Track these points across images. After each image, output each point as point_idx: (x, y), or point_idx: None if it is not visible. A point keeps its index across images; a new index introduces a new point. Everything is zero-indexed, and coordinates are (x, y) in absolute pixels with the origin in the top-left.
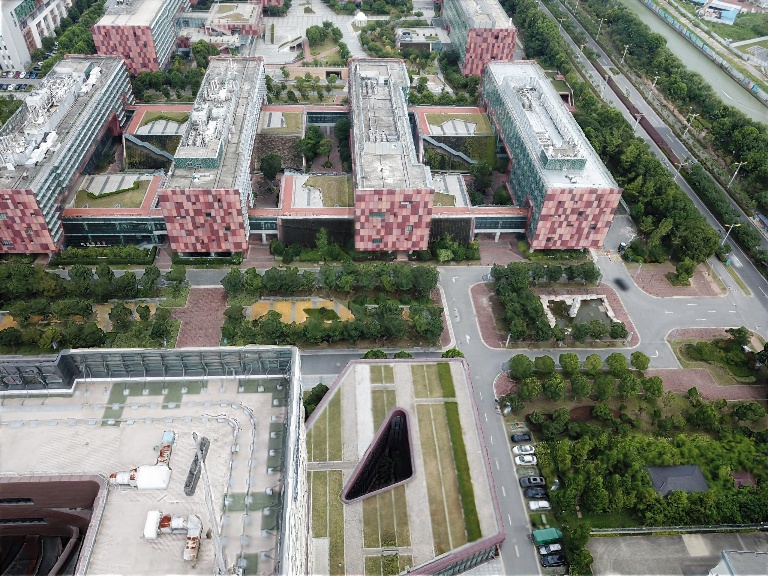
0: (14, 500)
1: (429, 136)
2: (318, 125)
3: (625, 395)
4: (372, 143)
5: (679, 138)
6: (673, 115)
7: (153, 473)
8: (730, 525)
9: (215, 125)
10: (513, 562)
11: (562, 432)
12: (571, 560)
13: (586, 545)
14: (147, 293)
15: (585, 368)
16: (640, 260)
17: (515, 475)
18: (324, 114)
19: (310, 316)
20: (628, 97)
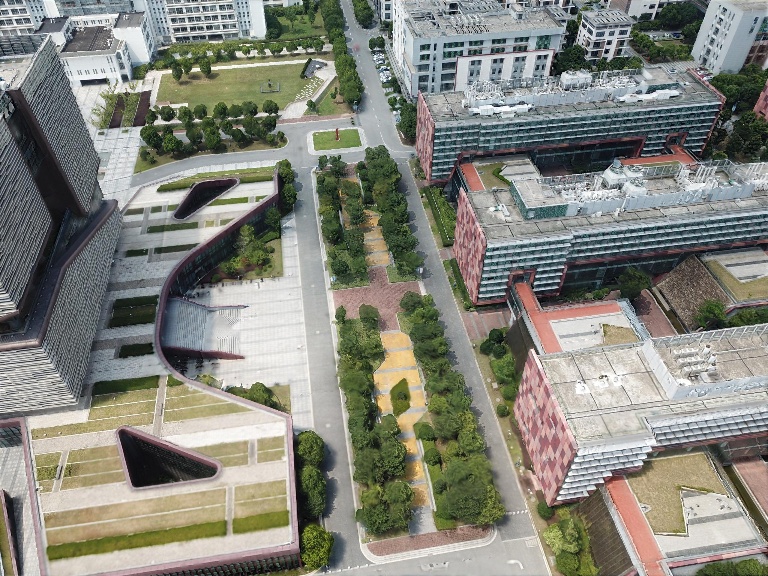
0: None
1: None
2: None
3: None
4: None
5: None
6: None
7: None
8: None
9: (610, 195)
10: None
11: None
12: None
13: None
14: (403, 254)
15: None
16: None
17: None
18: None
19: (395, 386)
20: None
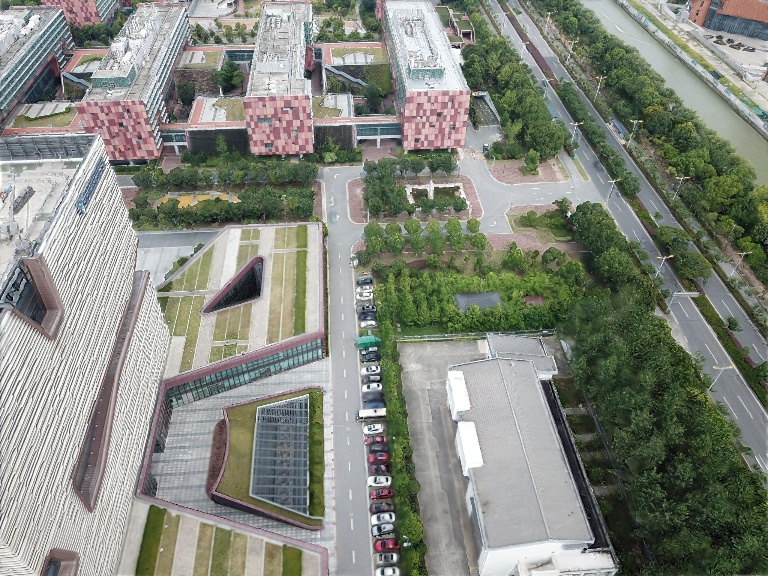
0: None
1: (330, 66)
2: (237, 63)
3: (454, 248)
4: (263, 63)
5: (563, 64)
6: (564, 46)
7: None
8: (517, 332)
9: None
10: (339, 360)
11: (397, 276)
12: (383, 356)
13: (399, 348)
14: None
15: None
16: (499, 157)
17: (354, 306)
18: (241, 52)
19: None
20: (526, 33)
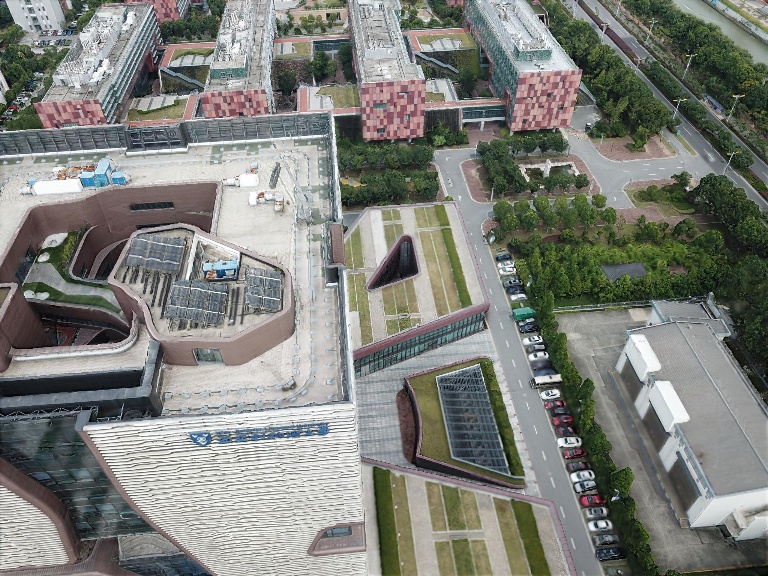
0: (162, 204)
1: (420, 52)
2: None
3: (586, 223)
4: (372, 50)
5: (642, 44)
6: (638, 27)
7: (249, 177)
8: None
9: (239, 46)
10: (498, 332)
11: None
12: (542, 326)
13: None
14: None
15: (554, 208)
16: (603, 136)
17: (499, 281)
18: (328, 42)
19: None
20: (598, 15)
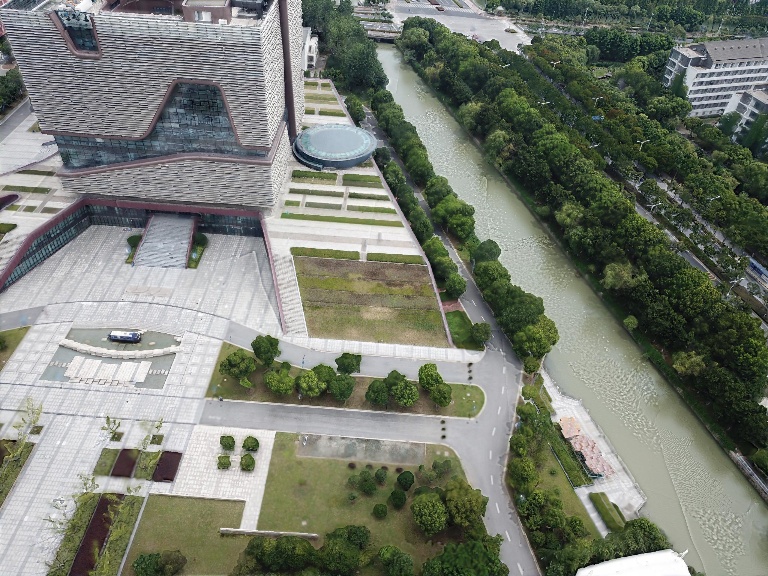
0: None
1: None
2: None
3: None
4: None
5: None
6: None
7: None
8: None
9: None
10: None
11: None
12: None
13: None
14: None
15: None
16: None
17: None
18: None
19: None
20: None
